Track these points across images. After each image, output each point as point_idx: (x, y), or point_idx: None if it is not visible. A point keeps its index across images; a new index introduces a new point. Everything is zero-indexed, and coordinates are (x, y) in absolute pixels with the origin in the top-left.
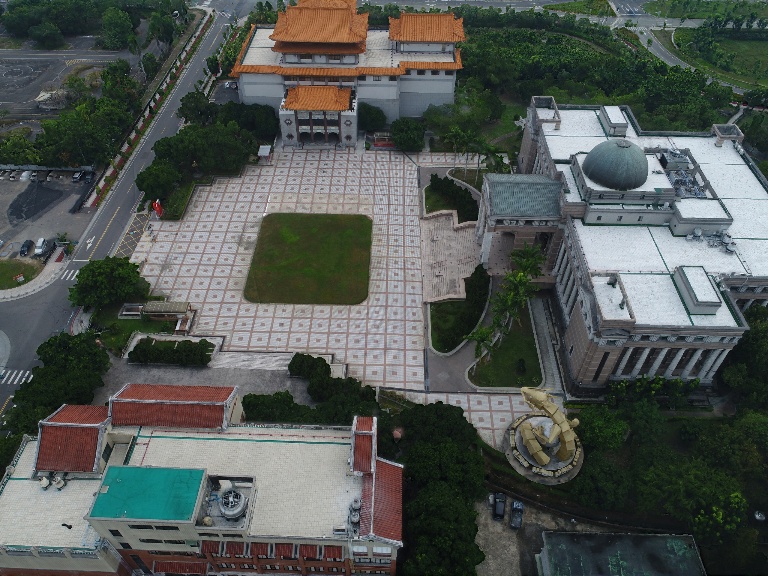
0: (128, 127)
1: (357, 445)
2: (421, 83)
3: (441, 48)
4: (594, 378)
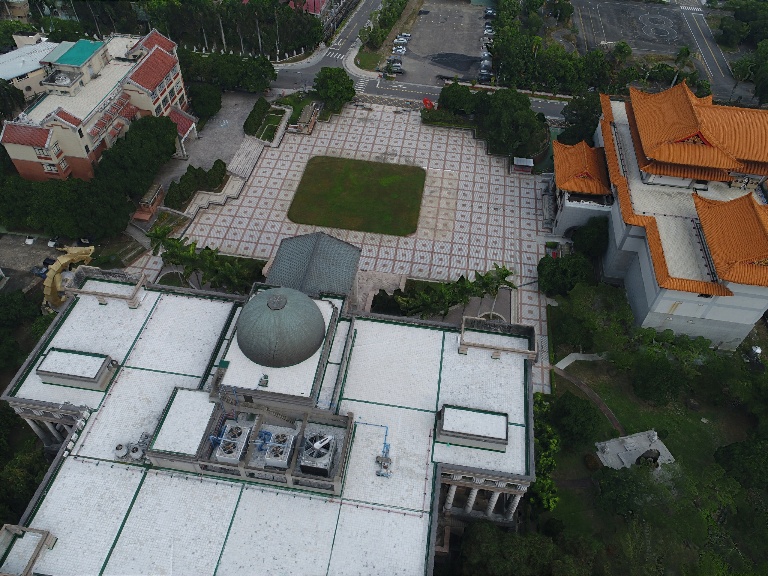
0: (566, 89)
1: None
2: None
3: None
4: None
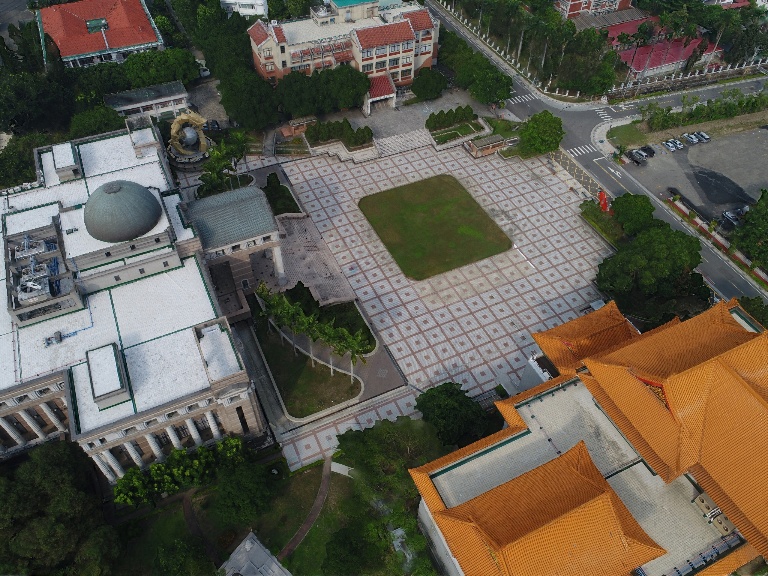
0: None
1: None
2: None
3: None
4: None
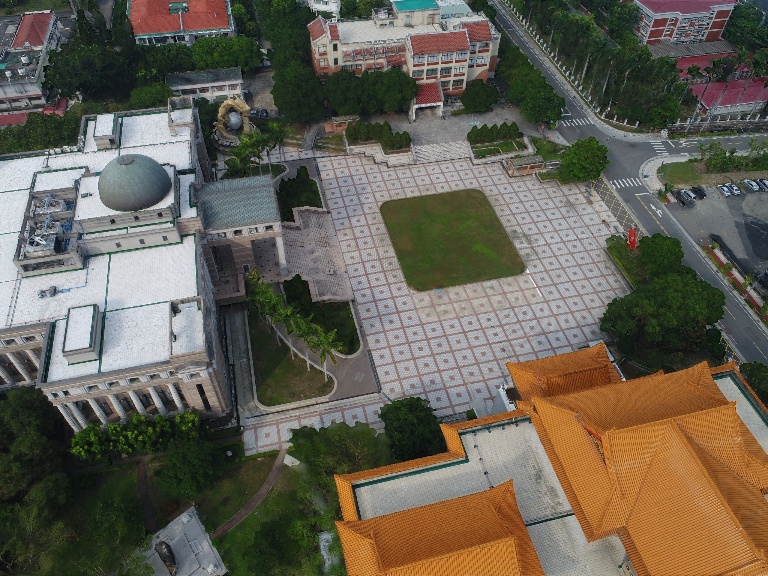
0: None
1: None
2: None
3: None
4: None
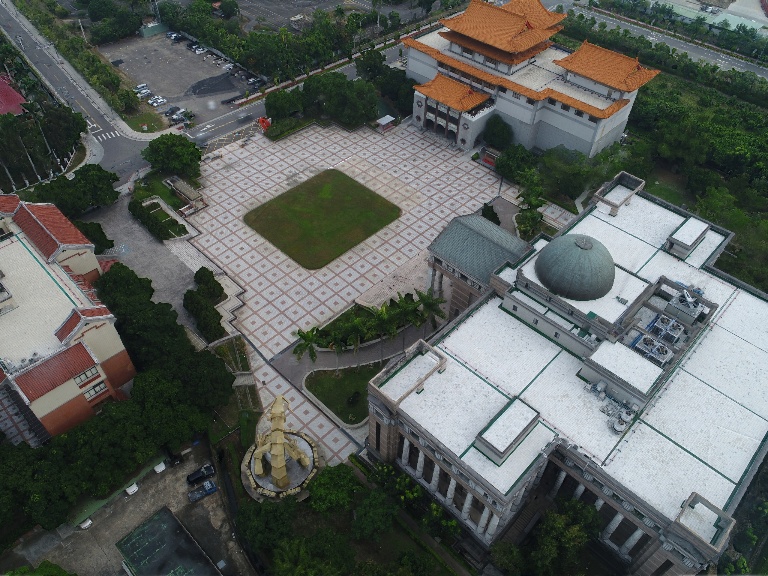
0: (322, 61)
1: (71, 319)
2: (563, 119)
3: (607, 92)
4: (377, 447)
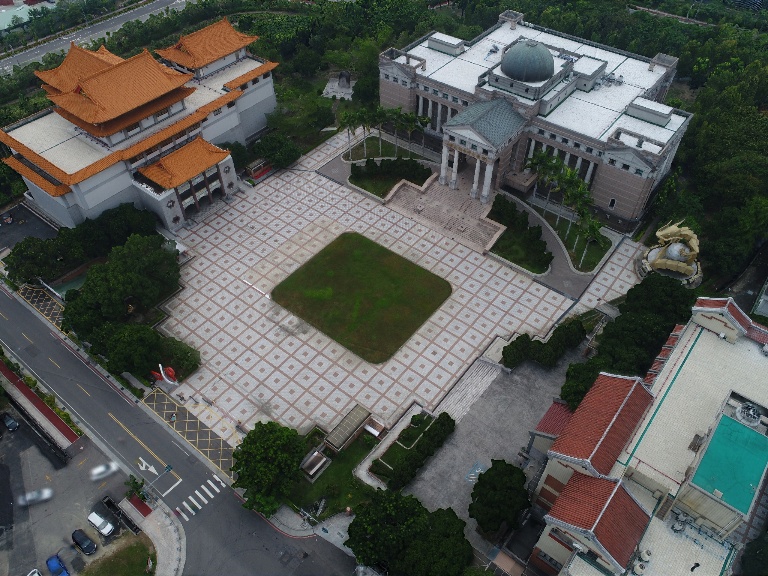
0: None
1: (732, 315)
2: (246, 98)
3: (235, 57)
4: (642, 208)
